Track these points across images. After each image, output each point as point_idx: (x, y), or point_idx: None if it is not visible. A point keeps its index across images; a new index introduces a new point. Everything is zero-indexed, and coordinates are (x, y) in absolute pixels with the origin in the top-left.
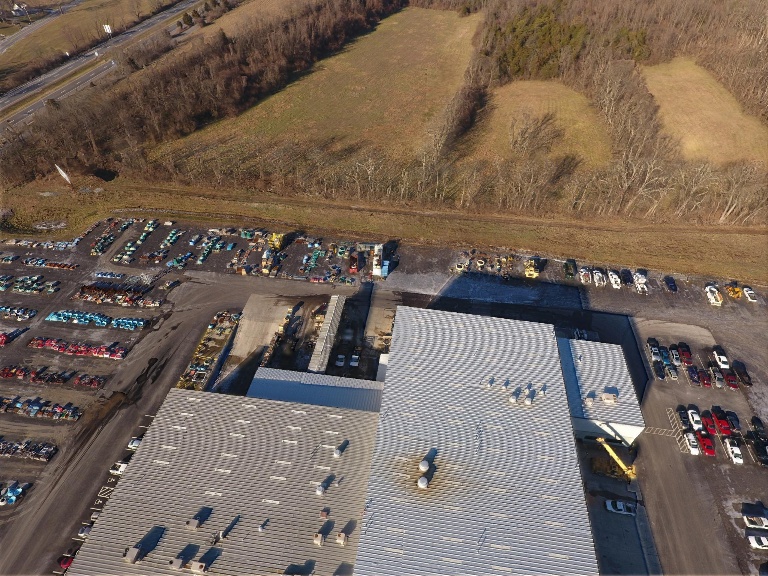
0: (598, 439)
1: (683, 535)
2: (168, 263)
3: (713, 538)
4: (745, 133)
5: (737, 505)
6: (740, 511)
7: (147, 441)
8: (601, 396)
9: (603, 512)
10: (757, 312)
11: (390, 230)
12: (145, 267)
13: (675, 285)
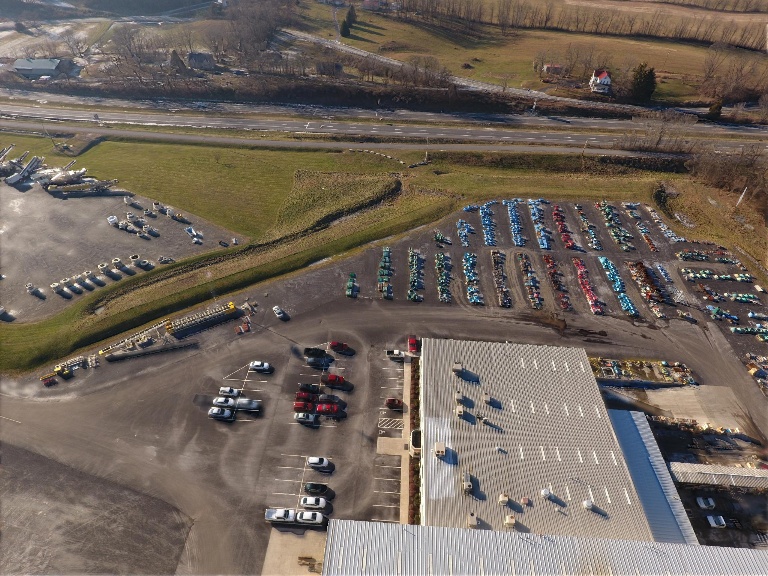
0: None
1: None
2: (710, 306)
3: None
4: None
5: None
6: None
7: (534, 348)
8: None
9: None
10: None
11: None
12: (692, 292)
13: None
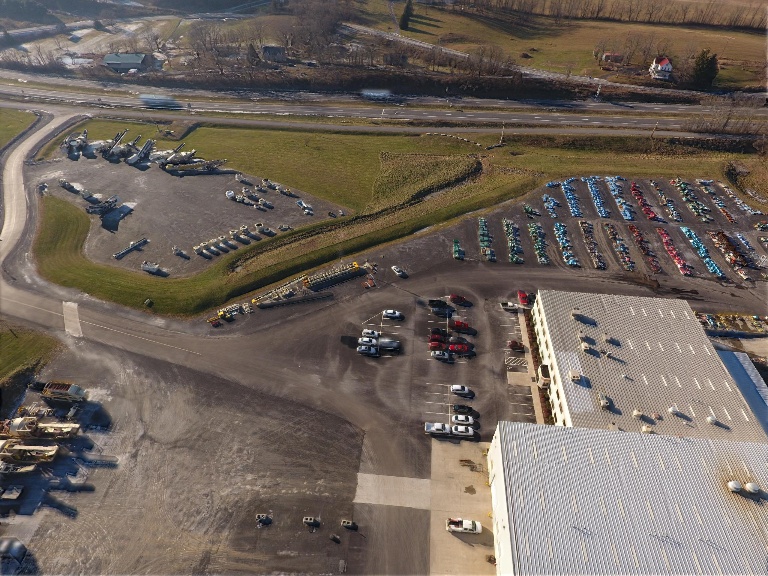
0: None
1: None
2: None
3: None
4: None
5: None
6: None
7: (641, 299)
8: None
9: None
10: None
11: None
12: None
13: None
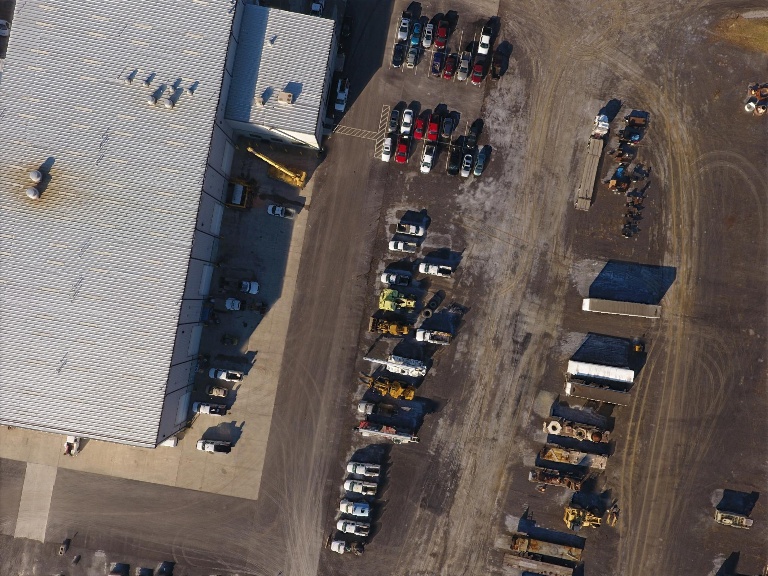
0: (248, 149)
1: (333, 237)
2: None
3: (360, 241)
4: None
5: (401, 212)
6: (400, 218)
7: None
8: None
9: (265, 215)
10: None
11: None
12: None
13: None
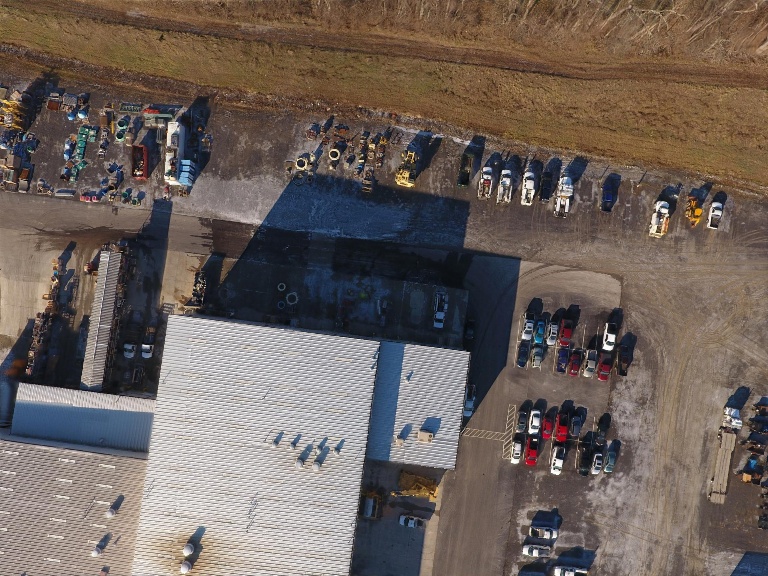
0: None
1: (465, 542)
2: None
3: (492, 544)
4: None
5: (532, 513)
6: (532, 519)
7: None
8: (417, 431)
9: (396, 523)
10: (706, 247)
11: (198, 72)
12: None
13: (616, 194)
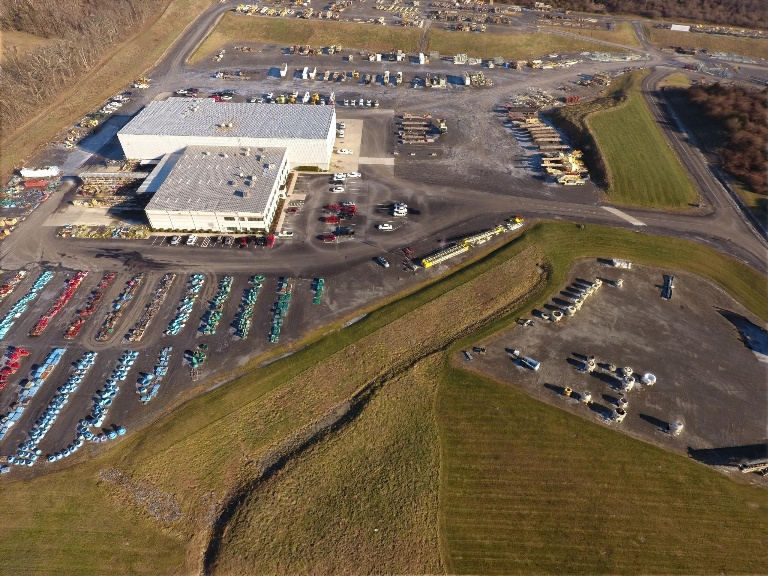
0: None
1: None
2: None
3: None
4: (8, 38)
5: None
6: None
7: (183, 208)
8: None
9: None
10: (157, 81)
11: None
12: None
13: None
